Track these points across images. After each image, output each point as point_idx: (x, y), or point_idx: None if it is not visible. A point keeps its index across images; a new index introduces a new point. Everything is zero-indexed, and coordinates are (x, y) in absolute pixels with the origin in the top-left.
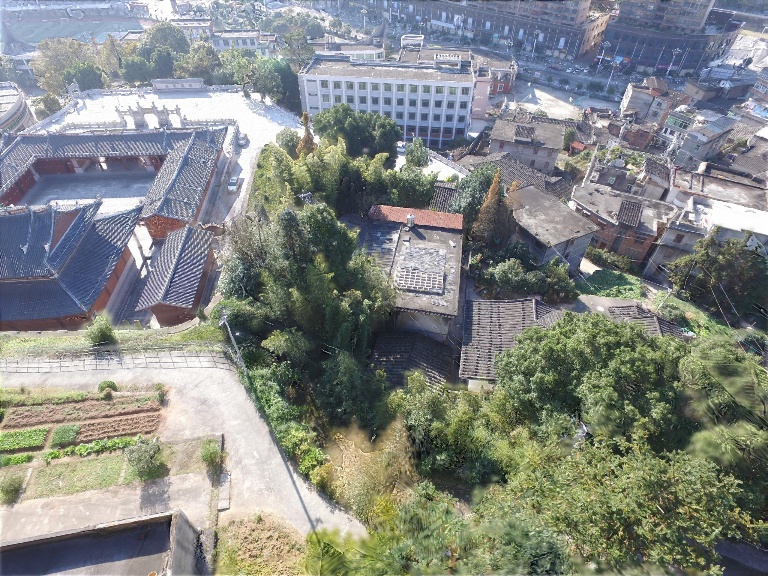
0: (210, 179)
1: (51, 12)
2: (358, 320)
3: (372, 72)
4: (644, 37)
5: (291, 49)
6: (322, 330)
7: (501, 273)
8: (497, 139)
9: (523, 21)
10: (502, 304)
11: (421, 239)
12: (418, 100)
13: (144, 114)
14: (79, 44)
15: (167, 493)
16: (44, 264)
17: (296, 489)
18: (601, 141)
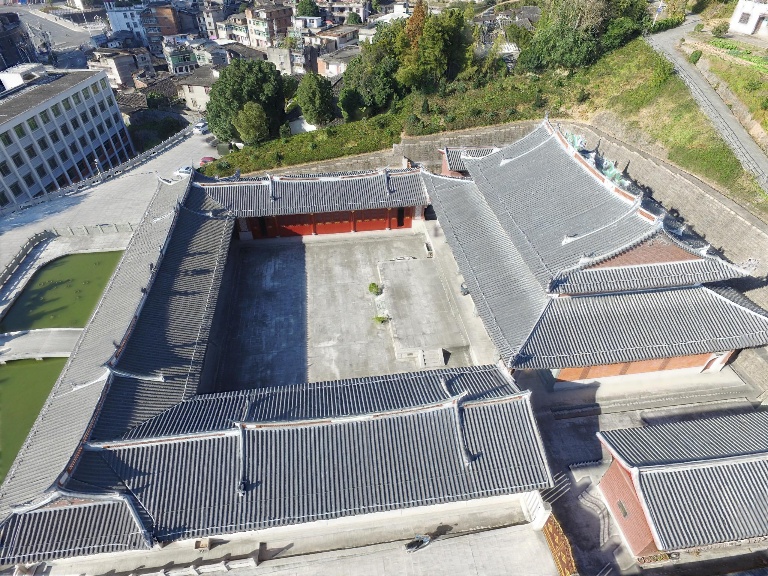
0: None
1: None
2: None
3: None
4: None
5: None
6: None
7: None
8: None
9: None
10: None
11: None
12: (78, 117)
13: None
14: None
15: None
16: None
17: None
18: None
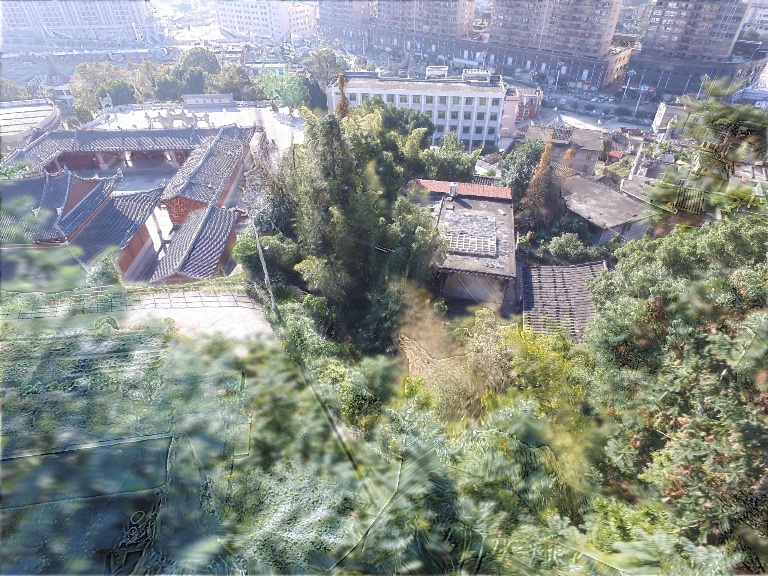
0: (236, 173)
1: (94, 56)
2: (410, 250)
3: (400, 86)
4: (670, 66)
5: (320, 67)
6: (364, 269)
7: (557, 246)
8: None
9: (545, 55)
10: (566, 269)
11: (466, 208)
12: (447, 112)
13: (173, 121)
14: (116, 68)
15: None
16: (55, 227)
17: (337, 434)
18: None
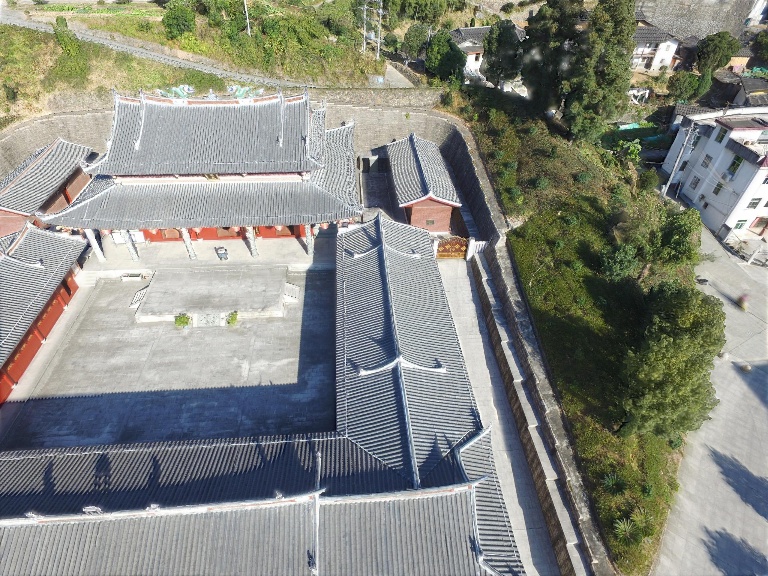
0: None
1: None
2: None
3: None
4: None
5: None
6: None
7: None
8: None
9: None
10: None
11: None
12: None
13: None
14: None
15: None
16: None
17: None
18: None
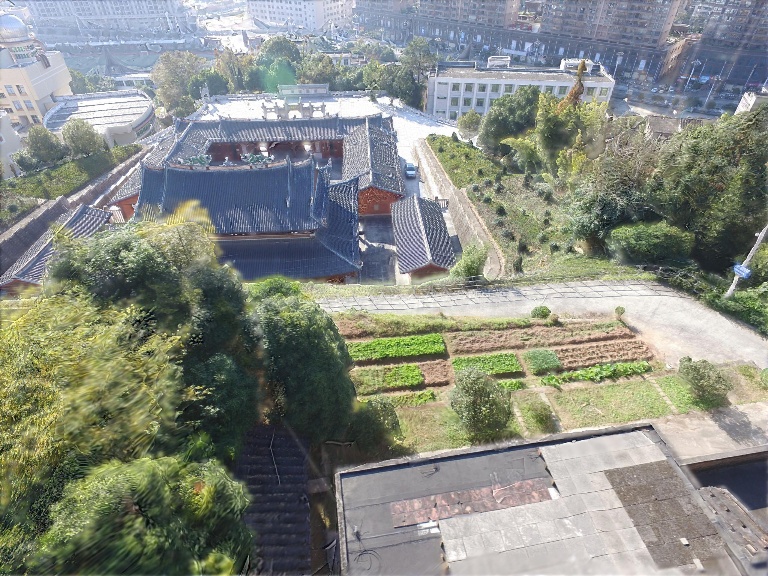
0: None
1: (131, 46)
2: None
3: (503, 75)
4: (734, 56)
5: (413, 57)
6: None
7: None
8: (661, 132)
9: (600, 45)
10: None
11: None
12: None
13: (289, 111)
14: (196, 58)
15: (752, 424)
16: (312, 218)
17: None
18: None
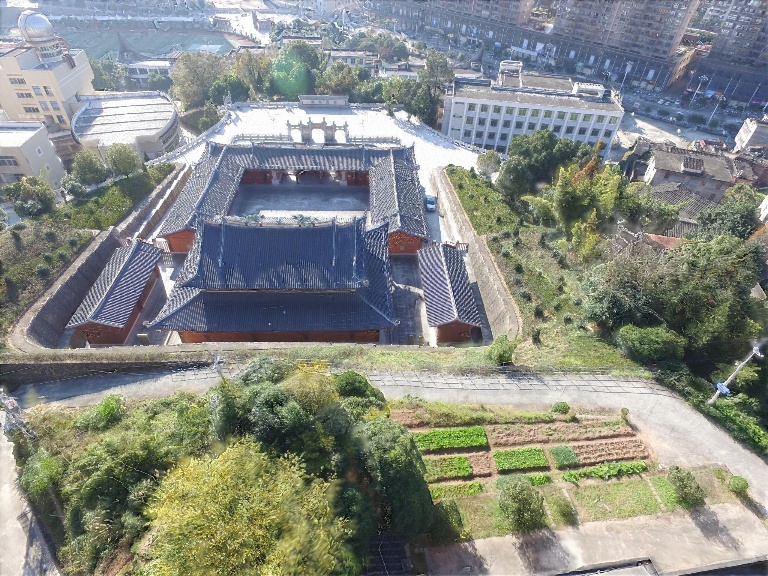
0: None
1: (139, 23)
2: None
3: (517, 97)
4: (740, 73)
5: (431, 71)
6: None
7: None
8: (664, 169)
9: (611, 52)
10: None
11: None
12: (563, 126)
13: (312, 129)
14: (215, 57)
15: (720, 523)
16: (355, 277)
17: None
18: (746, 175)
